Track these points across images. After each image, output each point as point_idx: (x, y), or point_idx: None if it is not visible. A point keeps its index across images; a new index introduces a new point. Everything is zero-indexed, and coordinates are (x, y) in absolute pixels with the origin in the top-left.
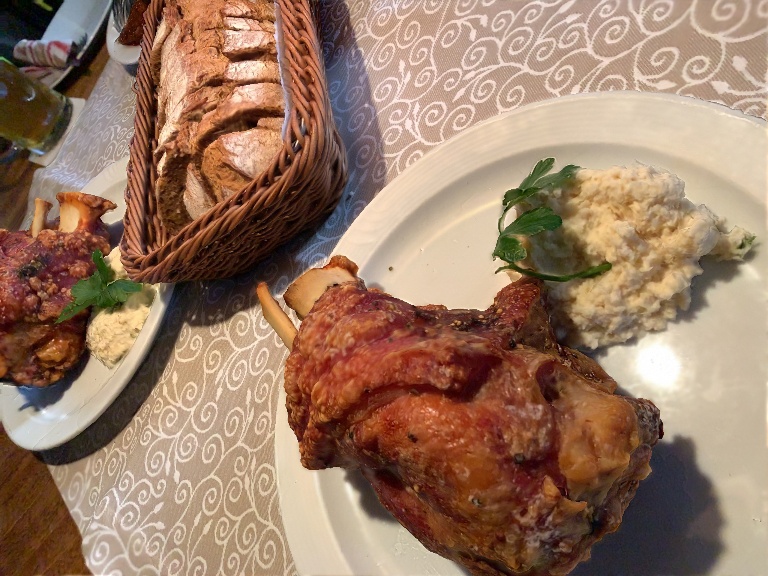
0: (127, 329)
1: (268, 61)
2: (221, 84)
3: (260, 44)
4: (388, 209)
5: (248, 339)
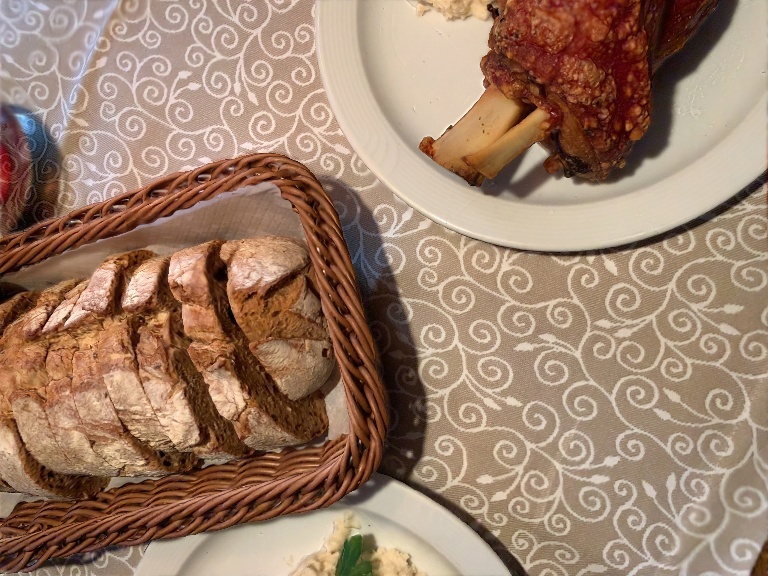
0: (407, 575)
1: (135, 272)
2: (138, 335)
3: (112, 271)
4: (369, 129)
5: (454, 359)
